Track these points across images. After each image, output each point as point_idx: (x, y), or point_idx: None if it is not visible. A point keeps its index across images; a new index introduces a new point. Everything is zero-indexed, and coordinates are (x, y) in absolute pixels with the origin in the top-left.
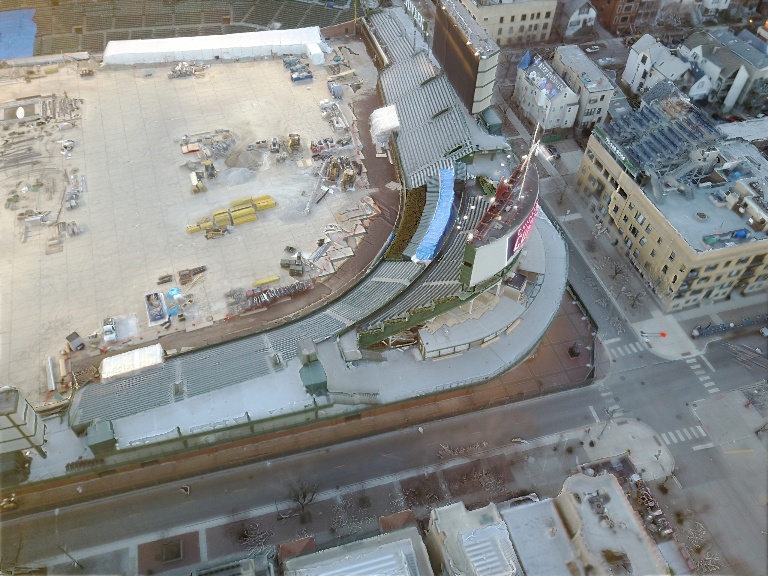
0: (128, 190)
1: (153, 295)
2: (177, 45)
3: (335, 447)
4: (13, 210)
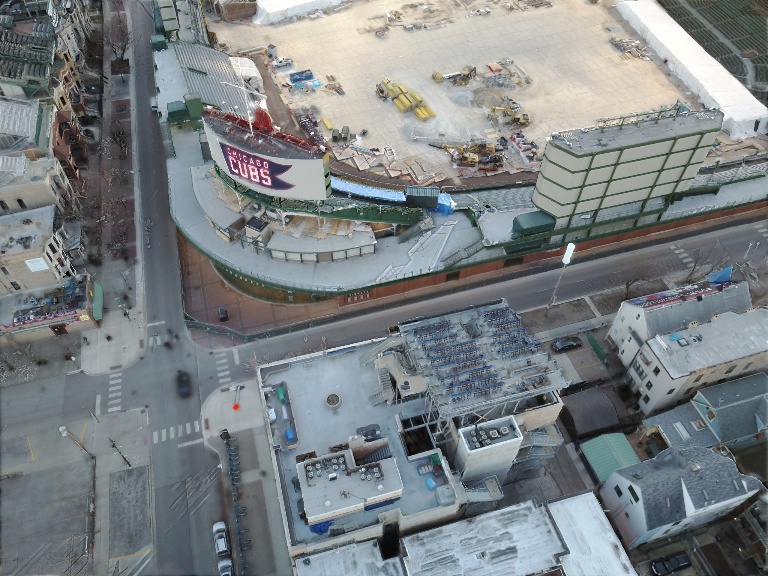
0: (431, 47)
1: (310, 72)
2: (666, 31)
3: None
4: (402, 8)
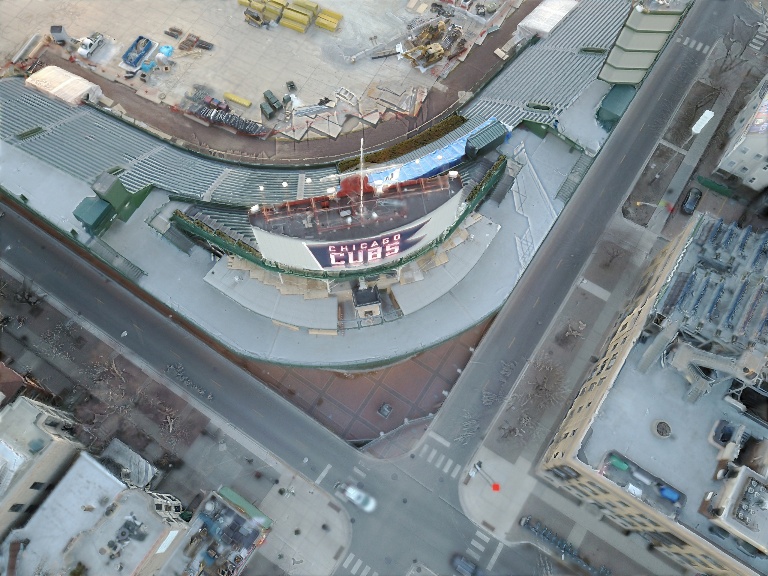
0: None
1: (145, 40)
2: None
3: (115, 284)
4: None
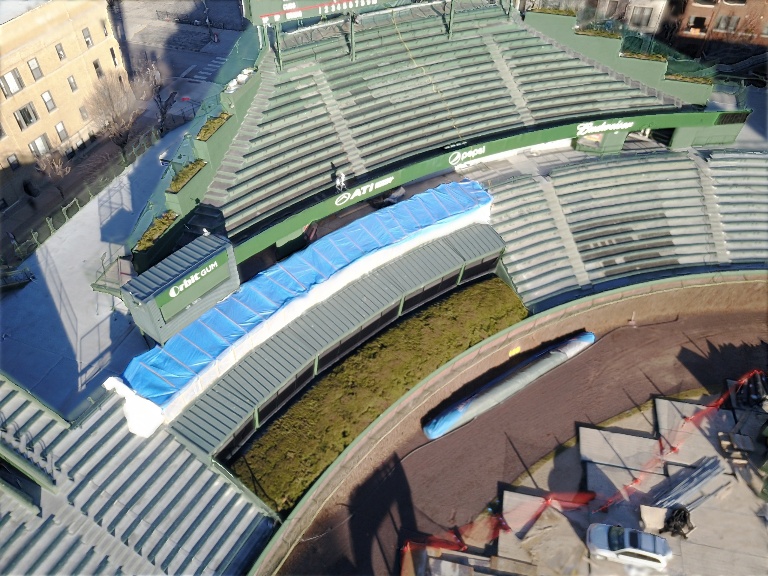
0: None
1: None
2: None
3: None
4: None
